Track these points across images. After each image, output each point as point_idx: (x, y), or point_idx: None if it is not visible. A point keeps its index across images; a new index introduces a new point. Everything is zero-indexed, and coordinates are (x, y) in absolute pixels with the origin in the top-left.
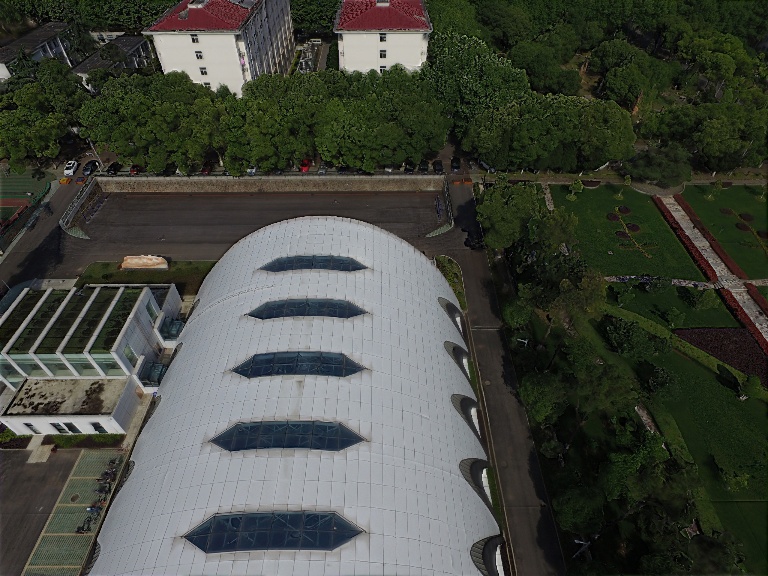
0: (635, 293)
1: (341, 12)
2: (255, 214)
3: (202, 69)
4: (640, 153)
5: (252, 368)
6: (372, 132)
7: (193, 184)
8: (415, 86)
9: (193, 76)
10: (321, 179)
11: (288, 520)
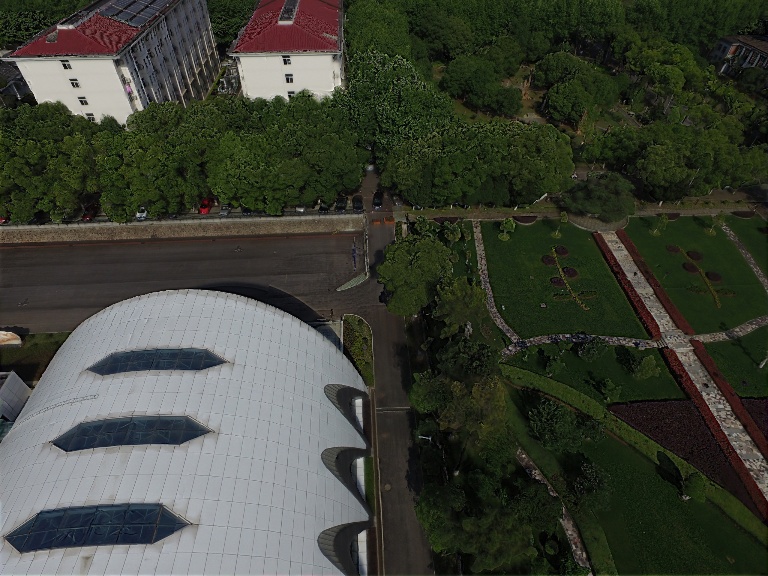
0: (568, 357)
1: (244, 30)
2: (142, 267)
3: (81, 98)
4: (579, 183)
5: (30, 535)
6: (272, 171)
7: (73, 232)
8: (324, 115)
9: (72, 106)
10: (223, 222)
11: None
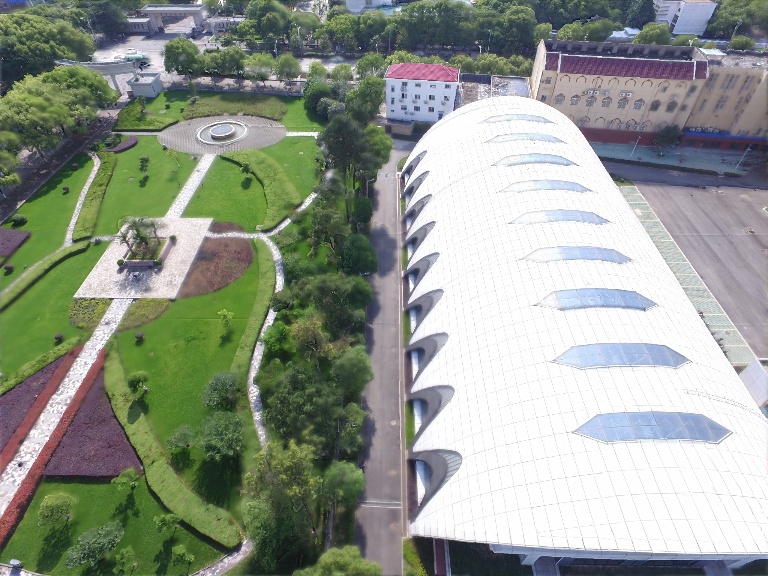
0: None
1: None
2: None
3: None
4: None
5: None
6: None
7: None
8: None
9: None
10: None
11: None
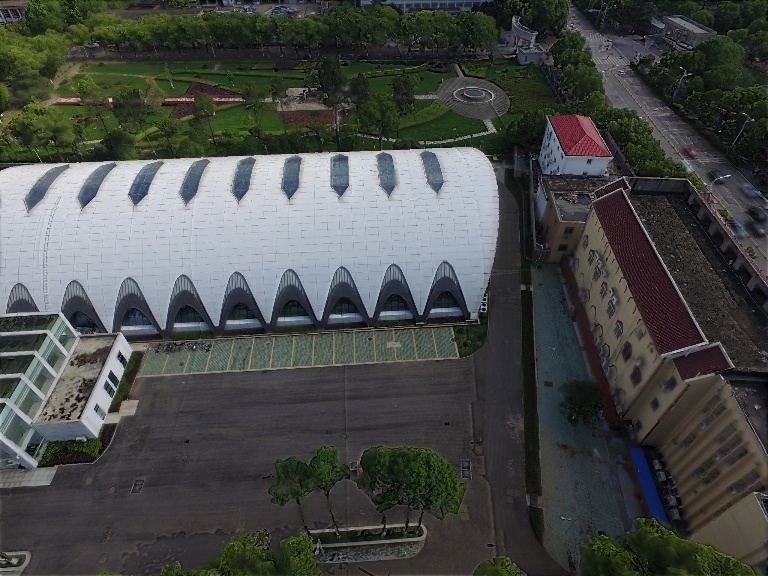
0: None
1: None
2: None
3: None
4: (8, 89)
5: (139, 194)
6: None
7: None
8: None
9: None
10: None
11: (240, 170)
